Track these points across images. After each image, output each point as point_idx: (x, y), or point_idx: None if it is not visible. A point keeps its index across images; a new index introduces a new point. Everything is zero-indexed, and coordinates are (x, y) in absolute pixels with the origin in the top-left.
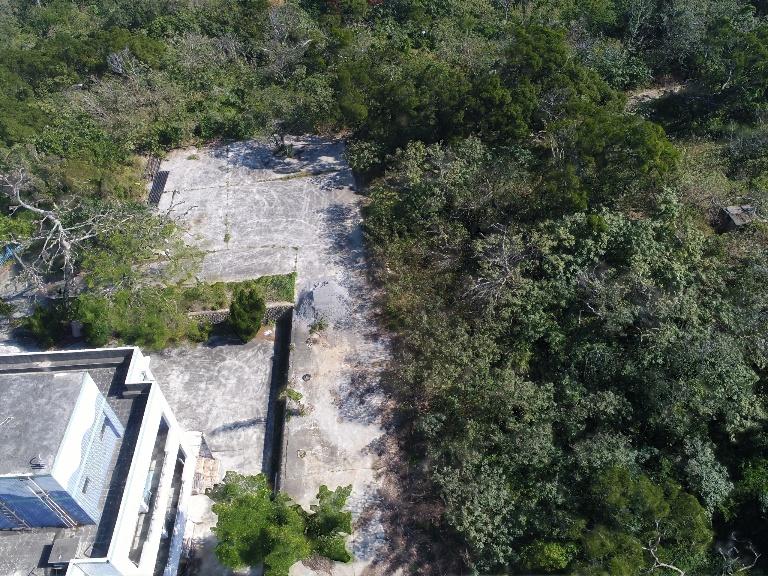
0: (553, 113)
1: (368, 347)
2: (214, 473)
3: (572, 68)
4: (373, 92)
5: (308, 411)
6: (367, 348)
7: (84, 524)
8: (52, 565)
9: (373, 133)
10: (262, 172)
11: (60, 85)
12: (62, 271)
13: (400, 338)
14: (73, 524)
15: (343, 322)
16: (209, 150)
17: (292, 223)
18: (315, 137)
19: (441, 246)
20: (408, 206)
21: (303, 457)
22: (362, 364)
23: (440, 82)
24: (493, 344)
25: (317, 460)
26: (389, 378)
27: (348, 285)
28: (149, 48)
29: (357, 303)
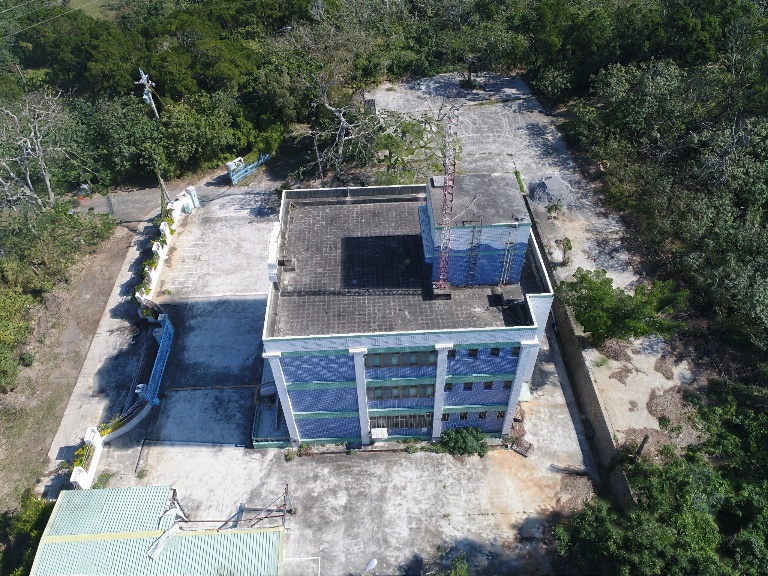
0: (736, 39)
1: (602, 221)
2: None
3: (745, 4)
4: (563, 28)
5: (569, 263)
6: (601, 222)
7: (510, 284)
8: (500, 305)
9: (557, 65)
10: (457, 100)
11: (249, 34)
12: (312, 173)
13: (627, 215)
14: (505, 282)
15: (574, 205)
16: (402, 84)
17: (499, 137)
18: (492, 74)
19: (652, 144)
20: (619, 114)
21: None
22: (602, 233)
23: (633, 15)
24: (730, 205)
25: None
26: (629, 241)
27: (567, 180)
28: (328, 1)
29: (580, 192)
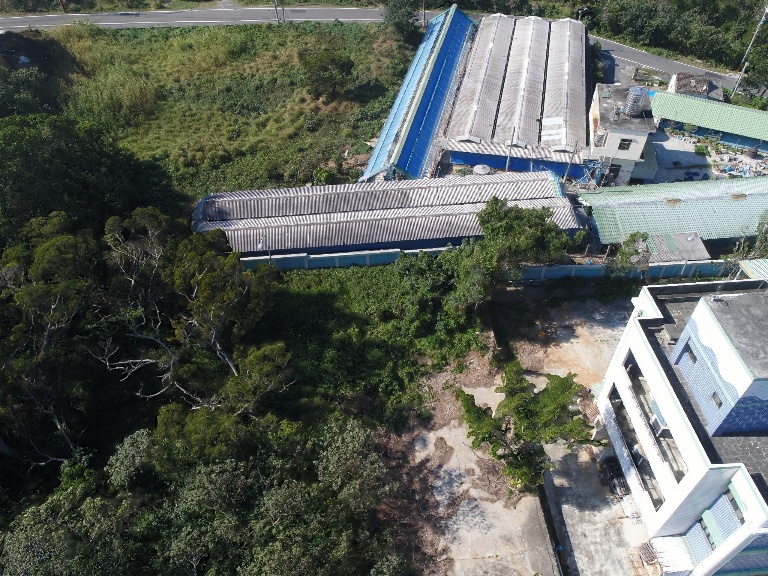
0: None
1: None
2: (634, 572)
3: None
4: None
5: None
6: None
7: None
8: None
9: None
10: None
11: None
12: None
13: None
14: None
15: None
16: None
17: None
18: None
19: None
20: None
21: (535, 575)
22: None
23: None
24: None
25: (518, 570)
26: None
27: None
28: None
29: None
